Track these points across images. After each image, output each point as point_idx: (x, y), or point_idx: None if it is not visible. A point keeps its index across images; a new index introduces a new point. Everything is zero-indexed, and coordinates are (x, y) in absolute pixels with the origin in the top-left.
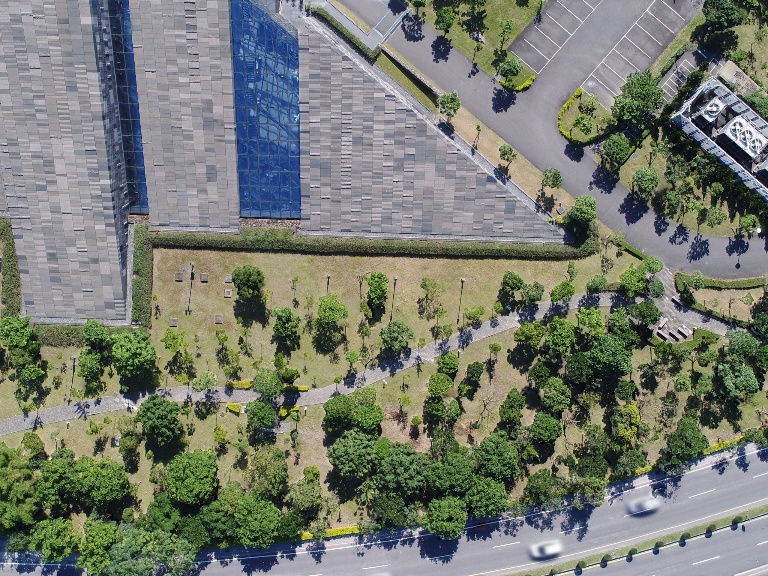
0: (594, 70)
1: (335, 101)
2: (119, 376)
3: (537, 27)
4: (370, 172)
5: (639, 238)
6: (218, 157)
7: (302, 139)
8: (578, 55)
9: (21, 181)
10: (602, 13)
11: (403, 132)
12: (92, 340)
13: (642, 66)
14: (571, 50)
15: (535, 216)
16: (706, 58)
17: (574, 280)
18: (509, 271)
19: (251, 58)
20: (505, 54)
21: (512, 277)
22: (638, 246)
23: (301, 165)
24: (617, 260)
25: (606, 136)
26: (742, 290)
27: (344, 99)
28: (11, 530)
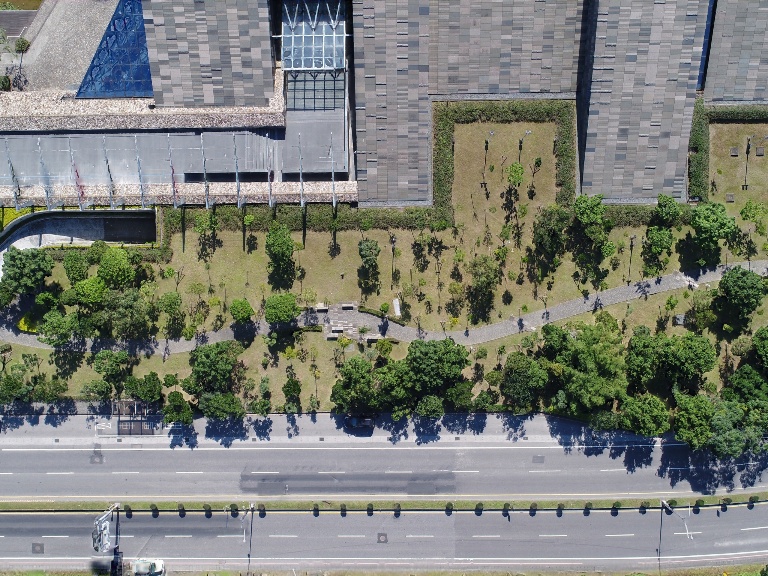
0: None
1: None
2: (678, 254)
3: None
4: None
5: None
6: None
7: None
8: None
9: (612, 52)
10: None
11: None
12: (672, 214)
13: None
14: None
15: None
16: None
17: None
18: None
19: None
20: None
21: None
22: None
23: None
24: None
25: None
26: None
27: None
28: (593, 409)
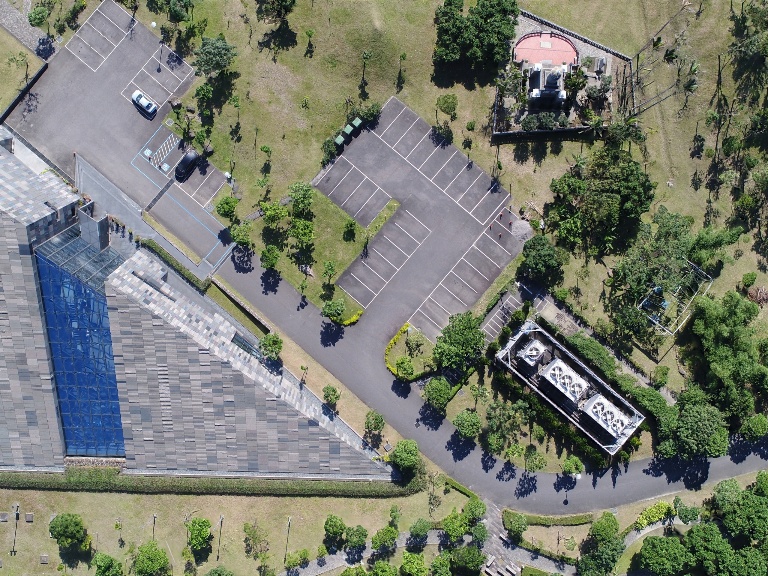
0: (421, 305)
1: (149, 354)
2: None
3: (364, 262)
4: (191, 417)
5: (466, 475)
6: (37, 404)
7: (119, 388)
8: (405, 290)
9: None
10: (428, 248)
11: (220, 382)
12: None
13: (469, 301)
14: (398, 285)
15: (360, 455)
16: (532, 294)
17: (402, 518)
18: (331, 516)
19: (72, 302)
20: (333, 288)
21: (332, 525)
22: (466, 483)
23: (121, 411)
24: (445, 497)
25: (432, 373)
26: (570, 526)
27: (158, 352)
28: None
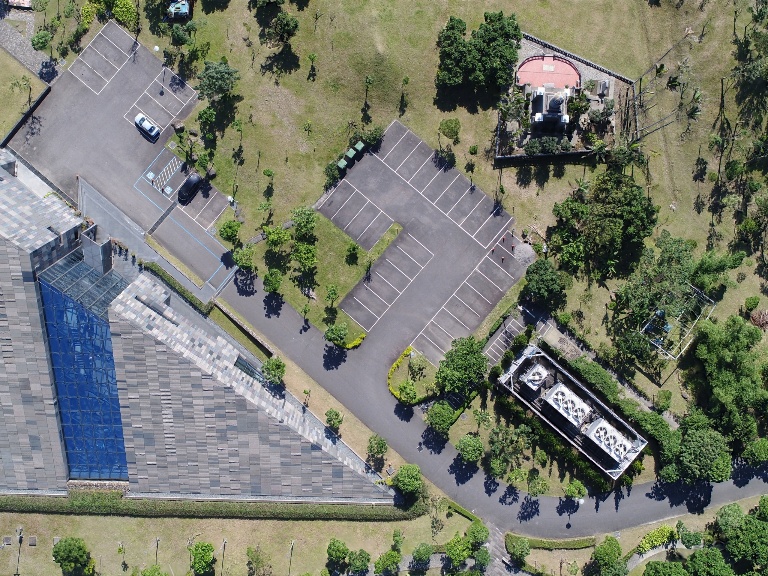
0: (424, 328)
1: (152, 380)
2: None
3: (366, 285)
4: (194, 441)
5: (469, 498)
6: (40, 429)
7: (123, 413)
8: (407, 313)
9: None
10: (431, 272)
11: (223, 406)
12: None
13: (471, 324)
14: (400, 308)
15: (363, 479)
16: (534, 317)
17: (404, 541)
18: (334, 540)
19: (75, 326)
20: (335, 311)
21: (335, 549)
22: (468, 506)
23: (124, 435)
24: (447, 521)
25: (435, 396)
26: (573, 550)
27: (161, 378)
28: None
